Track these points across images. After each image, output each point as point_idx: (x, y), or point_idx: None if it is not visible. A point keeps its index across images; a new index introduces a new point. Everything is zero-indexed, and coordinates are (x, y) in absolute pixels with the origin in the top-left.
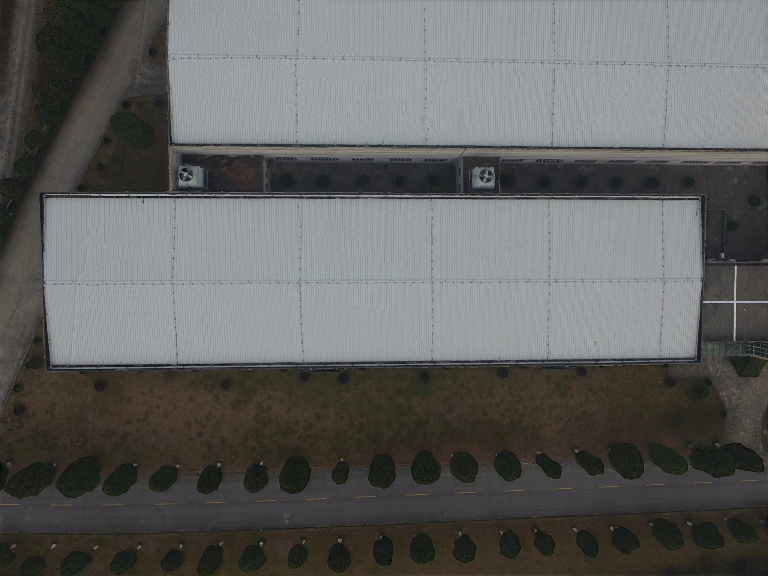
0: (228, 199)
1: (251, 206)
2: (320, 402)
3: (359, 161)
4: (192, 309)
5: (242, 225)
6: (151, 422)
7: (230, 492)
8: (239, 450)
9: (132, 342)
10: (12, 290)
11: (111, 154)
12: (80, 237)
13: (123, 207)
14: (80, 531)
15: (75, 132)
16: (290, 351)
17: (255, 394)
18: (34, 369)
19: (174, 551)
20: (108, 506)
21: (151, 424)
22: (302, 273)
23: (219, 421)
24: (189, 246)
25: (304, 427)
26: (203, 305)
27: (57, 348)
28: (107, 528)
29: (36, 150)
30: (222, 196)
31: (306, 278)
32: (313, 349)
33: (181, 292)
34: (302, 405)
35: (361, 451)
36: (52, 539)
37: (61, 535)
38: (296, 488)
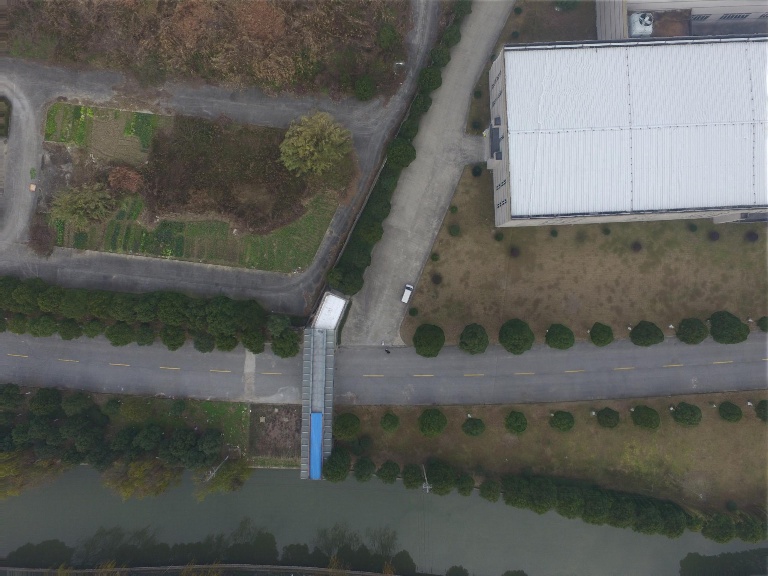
0: (677, 45)
1: (700, 51)
2: (727, 262)
3: (761, 19)
4: (648, 154)
5: (693, 70)
6: (562, 288)
7: (639, 357)
8: (648, 314)
9: (589, 190)
10: (427, 161)
11: (521, 24)
12: (539, 88)
13: (578, 57)
14: (492, 401)
15: (485, 5)
16: (741, 194)
17: (663, 256)
18: (451, 237)
19: (610, 409)
20: (520, 375)
21: (562, 290)
22: (755, 114)
23: (628, 285)
24: (643, 92)
25: (711, 288)
26: (659, 150)
27: (516, 198)
28: (518, 397)
29: (452, 23)
30: (671, 43)
31: (759, 119)
32: (764, 191)
33: (638, 137)
34: (709, 266)
35: (767, 311)
36: (466, 410)
37: (474, 406)
38: (746, 334)
